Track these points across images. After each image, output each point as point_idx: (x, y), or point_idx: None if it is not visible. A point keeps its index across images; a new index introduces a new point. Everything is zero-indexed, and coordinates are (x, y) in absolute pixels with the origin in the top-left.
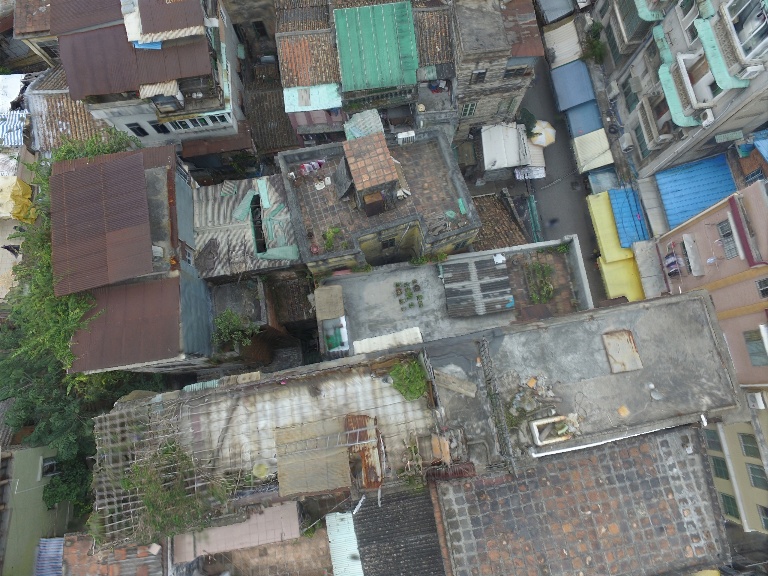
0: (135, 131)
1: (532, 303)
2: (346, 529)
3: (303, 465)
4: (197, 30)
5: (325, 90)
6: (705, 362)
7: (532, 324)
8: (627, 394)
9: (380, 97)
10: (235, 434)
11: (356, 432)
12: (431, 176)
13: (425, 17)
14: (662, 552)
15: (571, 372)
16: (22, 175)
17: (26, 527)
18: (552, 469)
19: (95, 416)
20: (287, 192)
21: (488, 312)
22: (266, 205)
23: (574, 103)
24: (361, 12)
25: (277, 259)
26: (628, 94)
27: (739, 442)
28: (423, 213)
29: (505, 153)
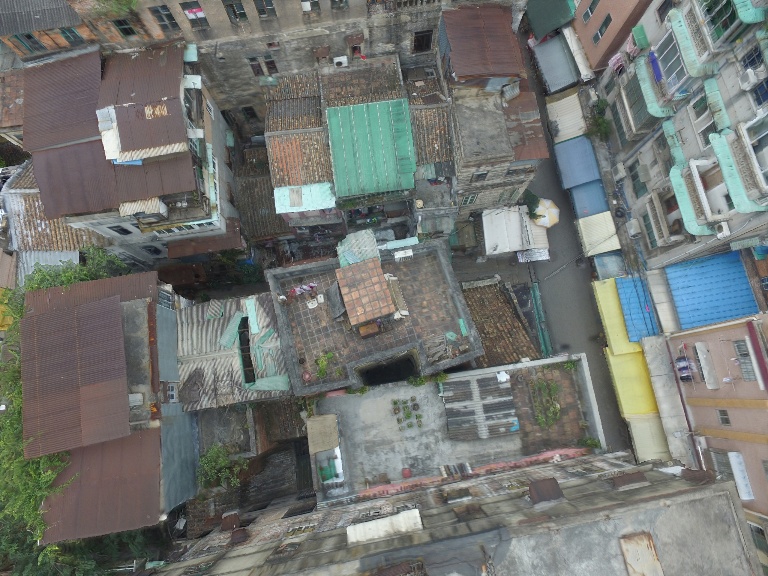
0: (118, 231)
1: (538, 424)
2: None
3: None
4: (180, 147)
5: (318, 189)
6: (733, 570)
7: (542, 525)
8: None
9: (376, 194)
10: None
11: None
12: (430, 293)
13: (423, 115)
14: None
15: None
16: None
17: None
18: None
19: (73, 558)
20: (277, 316)
21: (491, 436)
22: (255, 330)
23: (578, 182)
24: (355, 110)
25: (267, 390)
26: (635, 179)
27: None
28: (422, 335)
29: (507, 237)
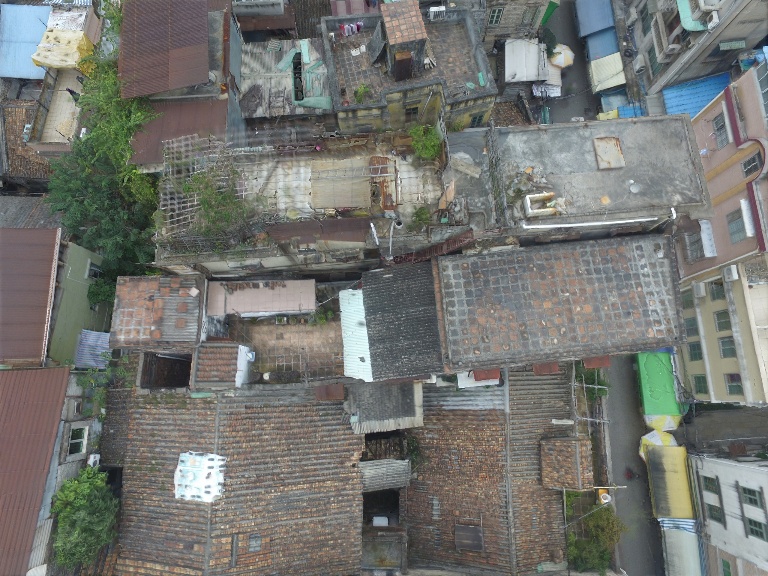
0: None
1: None
2: (356, 302)
3: (332, 188)
4: None
5: None
6: (680, 168)
7: (534, 126)
8: (610, 187)
9: None
10: (273, 188)
11: (378, 167)
12: (456, 52)
13: None
14: (627, 330)
15: (563, 166)
16: (88, 33)
17: (73, 312)
18: (539, 258)
19: None
20: (326, 50)
21: None
22: (306, 61)
23: (594, 29)
24: None
25: (312, 107)
26: (645, 19)
27: (714, 320)
28: (446, 82)
29: (525, 67)
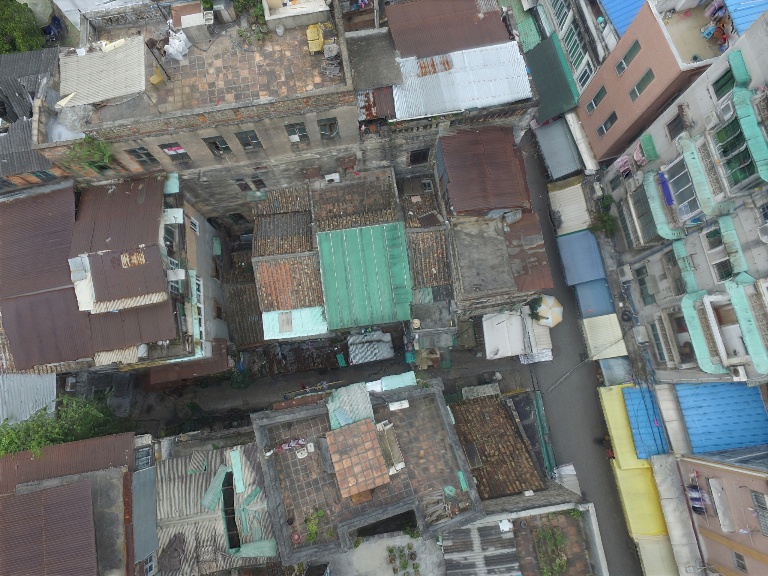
0: None
1: None
2: None
3: None
4: (158, 297)
5: (309, 313)
6: None
7: None
8: None
9: None
10: None
11: None
12: (428, 441)
13: (419, 238)
14: None
15: None
16: None
17: None
18: None
19: None
20: (264, 474)
21: None
22: (240, 488)
23: (583, 279)
24: (348, 235)
25: (252, 557)
26: (643, 284)
27: None
28: (419, 489)
29: (508, 341)
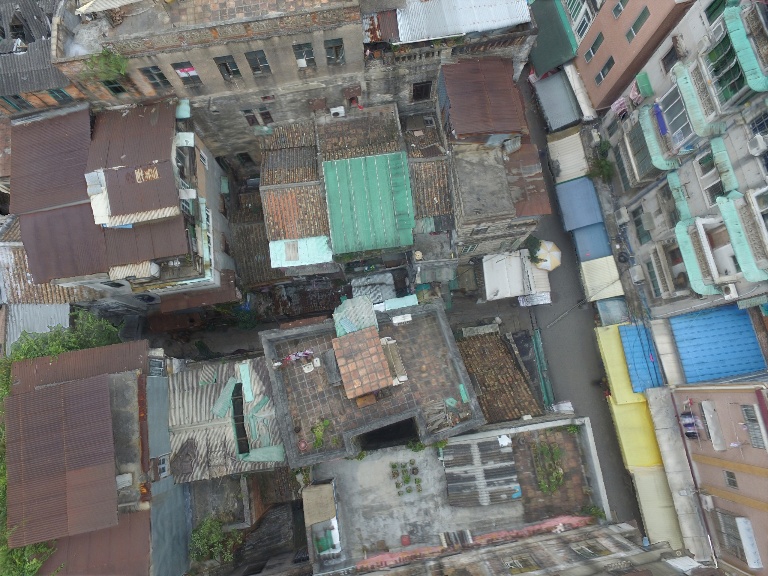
0: (109, 285)
1: (540, 490)
2: None
3: None
4: (171, 211)
5: (314, 243)
6: None
7: None
8: None
9: None
10: None
11: None
12: (429, 356)
13: (422, 168)
14: None
15: None
16: None
17: None
18: None
19: None
20: (272, 383)
21: (493, 503)
22: (249, 397)
23: (581, 224)
24: (352, 164)
25: (261, 461)
26: (639, 225)
27: None
28: (421, 401)
29: (508, 282)
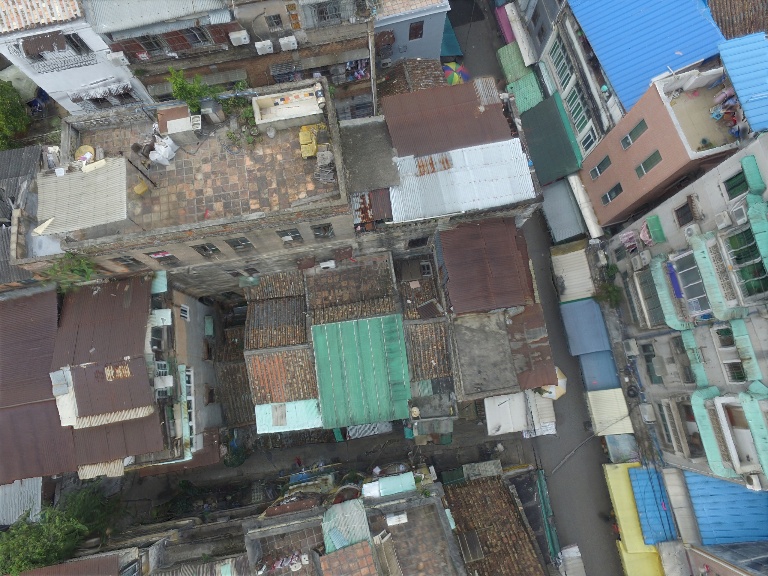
0: None
1: None
2: None
3: None
4: (144, 411)
5: (303, 406)
6: None
7: None
8: None
9: None
10: None
11: None
12: (427, 552)
13: (418, 330)
14: None
15: None
16: None
17: None
18: None
19: None
20: None
21: None
22: None
23: (587, 350)
24: (343, 328)
25: None
26: (649, 362)
27: None
28: None
29: (511, 417)
